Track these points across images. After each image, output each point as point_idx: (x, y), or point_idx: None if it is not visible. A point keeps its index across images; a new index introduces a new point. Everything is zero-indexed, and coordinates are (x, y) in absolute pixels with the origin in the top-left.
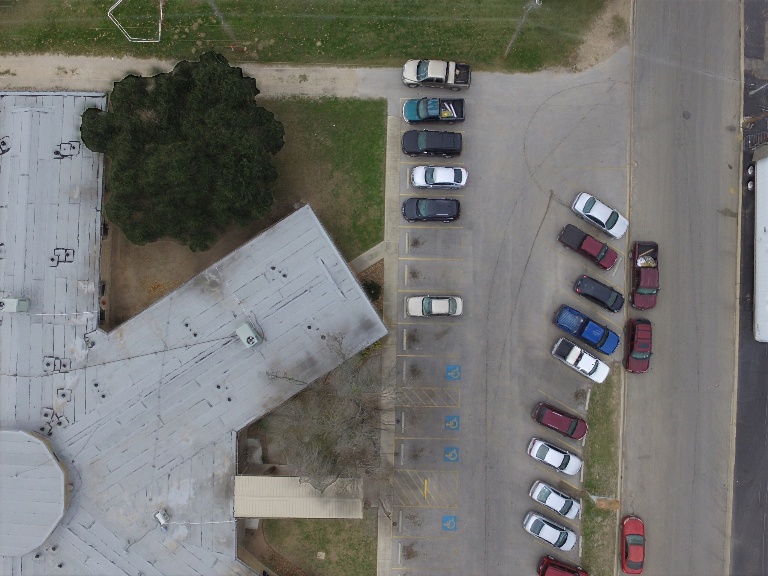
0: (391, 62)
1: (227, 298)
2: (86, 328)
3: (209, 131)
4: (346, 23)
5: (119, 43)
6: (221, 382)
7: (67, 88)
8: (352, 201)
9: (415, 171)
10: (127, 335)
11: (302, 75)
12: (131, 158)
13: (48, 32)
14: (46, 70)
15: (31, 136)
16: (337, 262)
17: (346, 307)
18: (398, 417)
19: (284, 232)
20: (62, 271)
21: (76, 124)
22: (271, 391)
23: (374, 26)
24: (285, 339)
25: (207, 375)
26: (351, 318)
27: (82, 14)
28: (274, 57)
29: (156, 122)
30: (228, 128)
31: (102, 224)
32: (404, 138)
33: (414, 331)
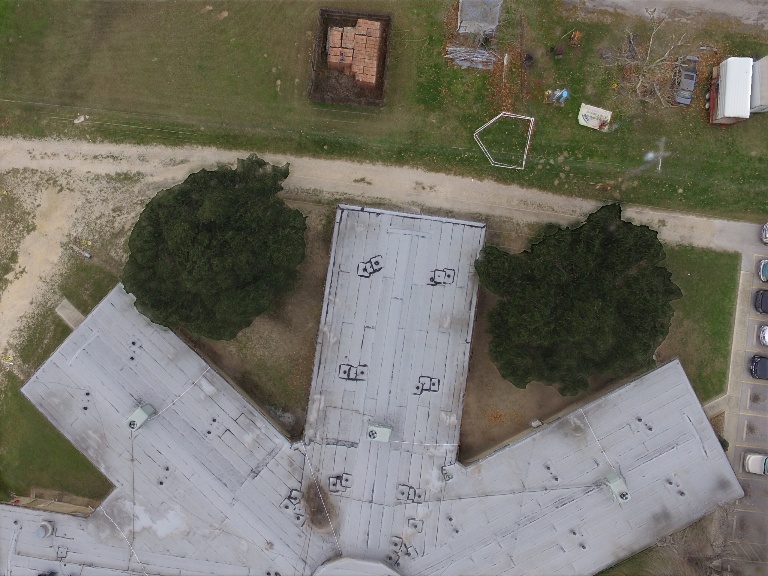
0: (749, 217)
1: (591, 445)
2: (445, 460)
3: (635, 296)
4: (710, 174)
5: (481, 165)
6: (577, 529)
7: (423, 204)
8: (700, 352)
9: (767, 330)
10: (486, 472)
11: (661, 220)
12: (550, 312)
13: (409, 145)
14: (403, 183)
15: (409, 260)
16: (702, 420)
17: (707, 466)
18: (724, 570)
19: (652, 385)
20: (425, 400)
21: (452, 252)
22: (625, 542)
23: (737, 180)
24: (645, 492)
25: (565, 521)
26: (711, 477)
27: (446, 131)
28: (636, 199)
29: (574, 277)
30: (652, 294)
31: (470, 356)
32: (763, 298)
33: (747, 486)
